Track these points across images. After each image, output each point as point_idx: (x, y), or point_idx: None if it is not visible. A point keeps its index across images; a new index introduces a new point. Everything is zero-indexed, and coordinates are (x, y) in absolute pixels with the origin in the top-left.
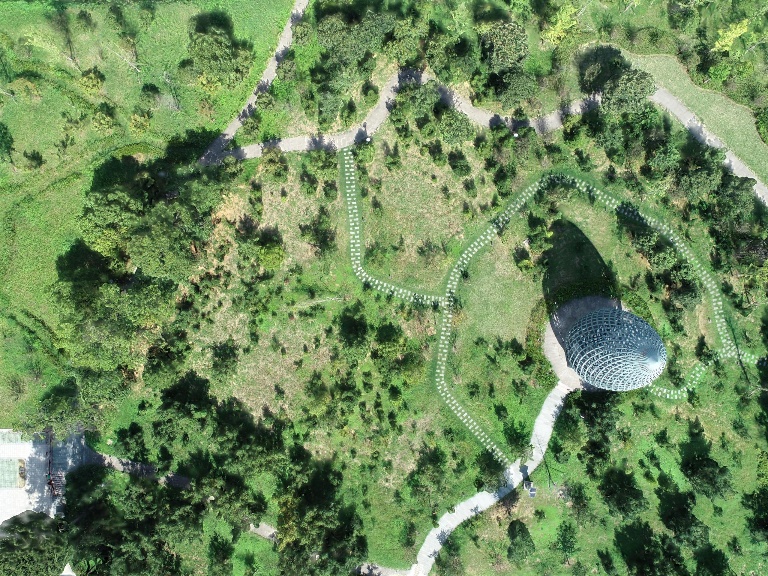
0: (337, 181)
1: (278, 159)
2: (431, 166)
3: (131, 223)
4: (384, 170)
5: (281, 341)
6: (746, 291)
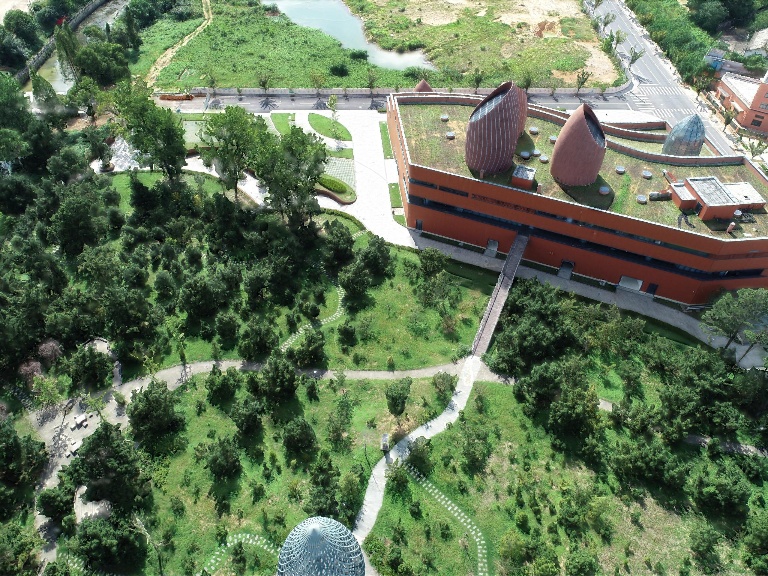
0: None
1: None
2: None
3: None
4: None
5: None
6: None
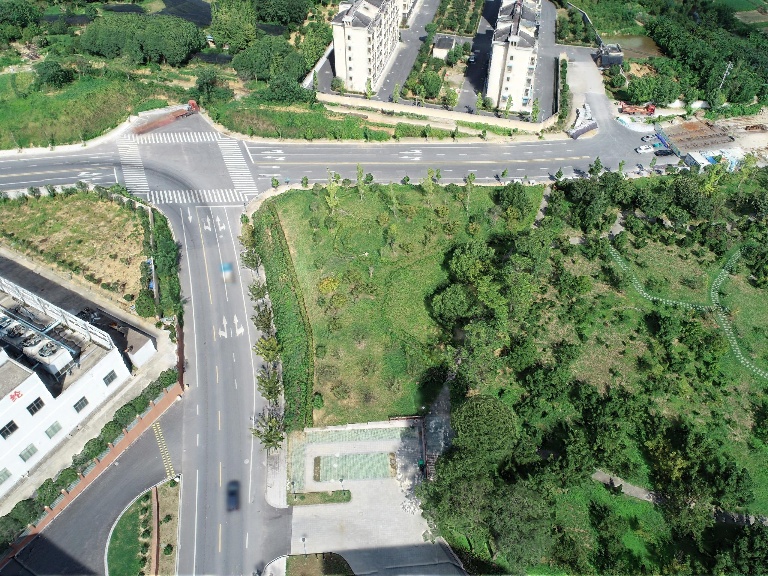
0: None
1: None
2: (664, 247)
3: (492, 257)
4: (634, 250)
5: (603, 340)
6: None
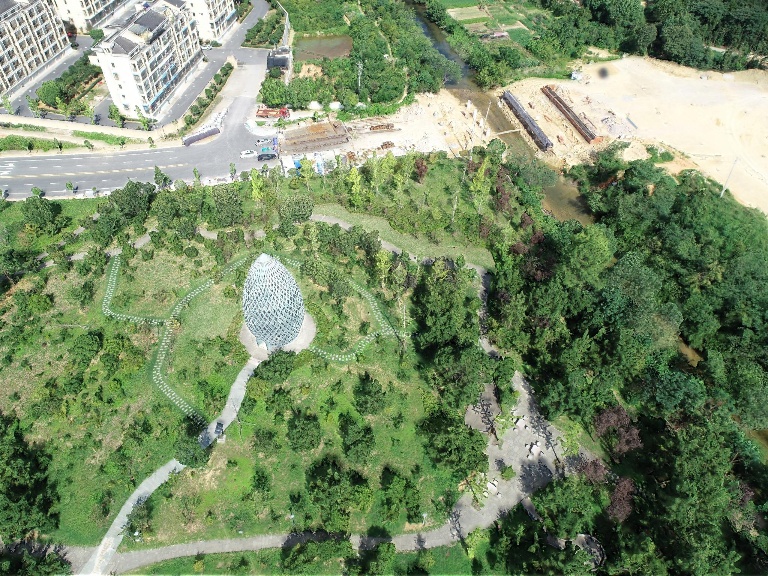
0: (106, 269)
1: (64, 256)
2: (174, 258)
3: None
4: (141, 263)
5: (31, 362)
6: (395, 297)
